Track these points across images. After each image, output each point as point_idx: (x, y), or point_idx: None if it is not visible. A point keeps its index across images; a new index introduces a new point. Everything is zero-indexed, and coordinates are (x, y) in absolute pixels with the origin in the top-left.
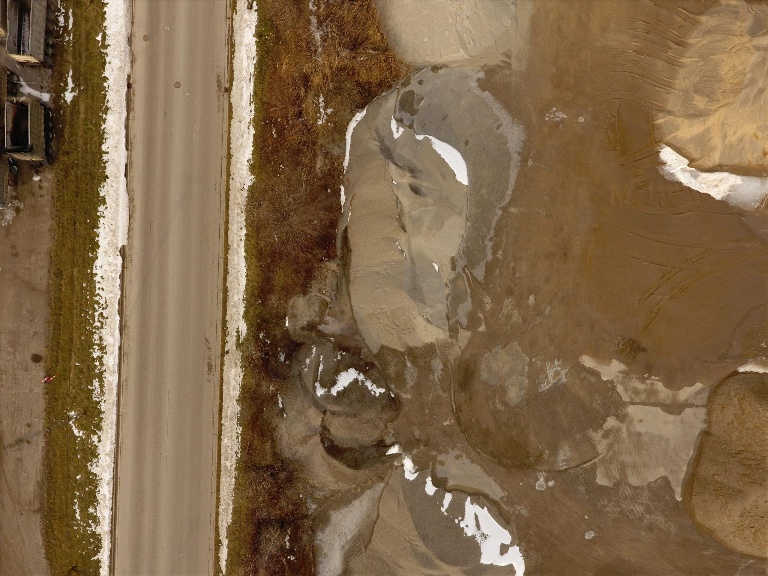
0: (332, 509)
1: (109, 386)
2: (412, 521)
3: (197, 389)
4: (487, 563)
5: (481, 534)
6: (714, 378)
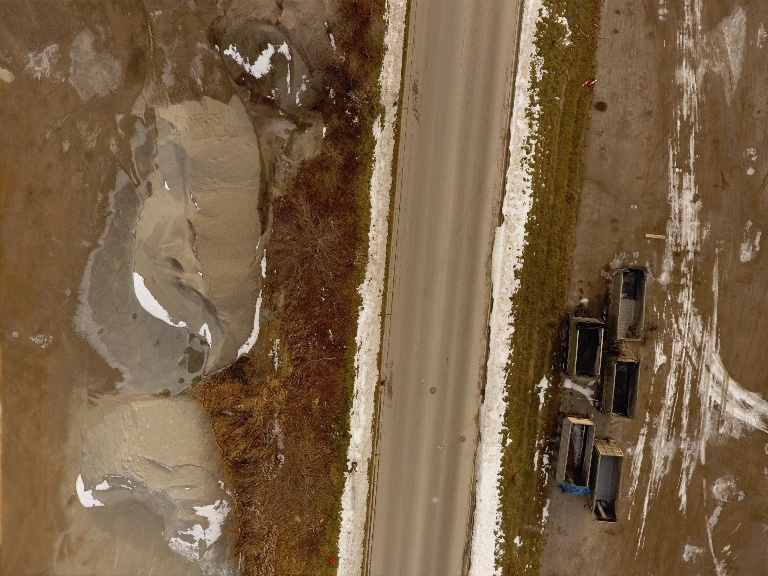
0: None
1: (525, 72)
2: None
3: (431, 65)
4: None
5: None
6: None
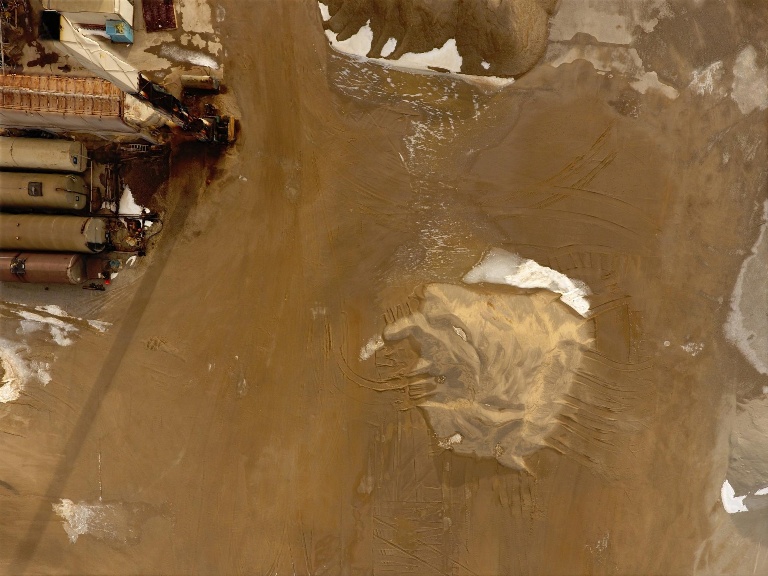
0: None
1: None
2: None
3: None
4: None
5: None
6: (539, 72)
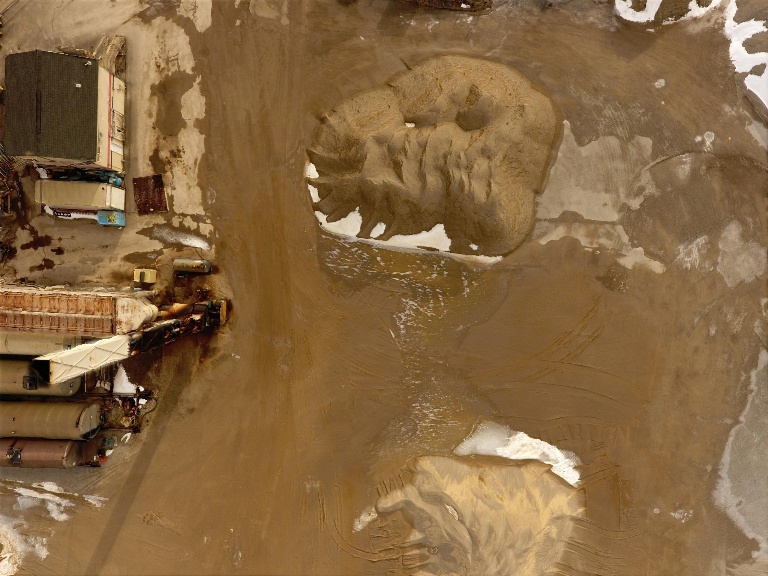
0: None
1: None
2: None
3: None
4: None
5: None
6: (527, 249)
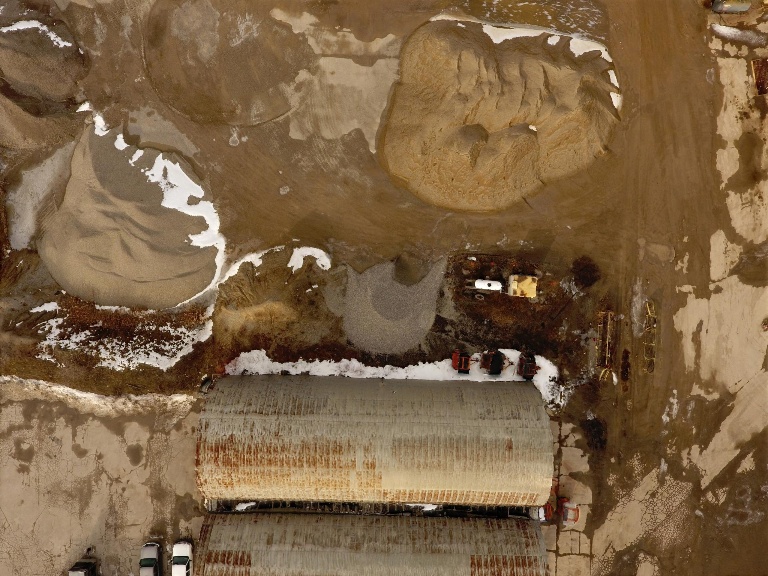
0: (23, 169)
1: None
2: (92, 165)
3: None
4: (169, 207)
5: (167, 182)
6: (406, 29)
